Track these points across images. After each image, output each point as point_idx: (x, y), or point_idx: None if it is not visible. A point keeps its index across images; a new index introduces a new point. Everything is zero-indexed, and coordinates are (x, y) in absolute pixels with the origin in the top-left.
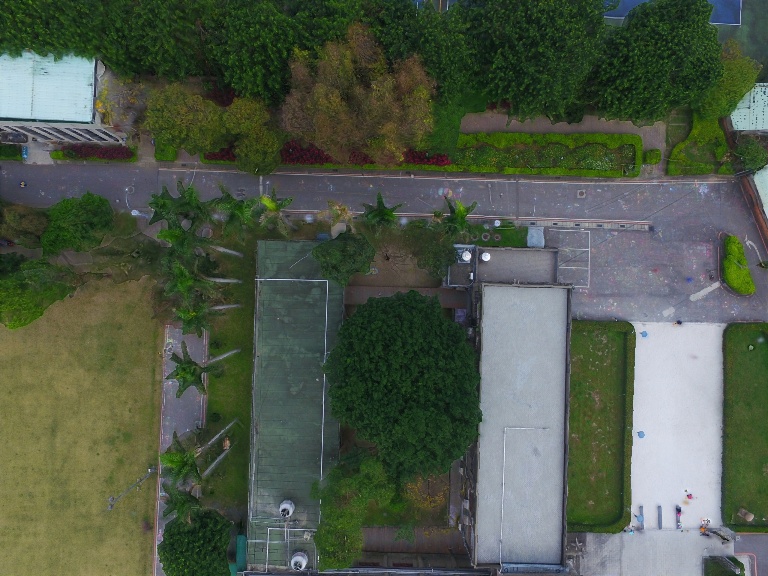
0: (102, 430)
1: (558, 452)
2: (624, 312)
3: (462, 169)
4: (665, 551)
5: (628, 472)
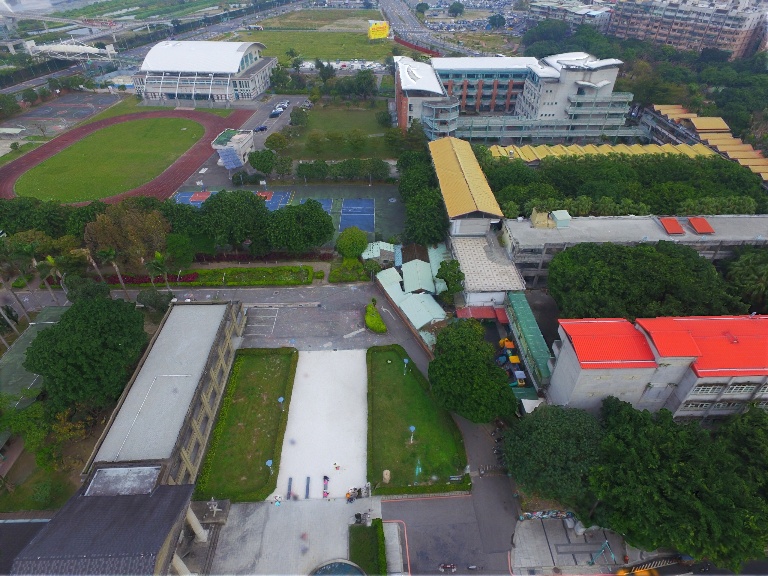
0: None
1: (193, 390)
2: (295, 346)
3: (201, 283)
4: (310, 521)
5: (278, 444)
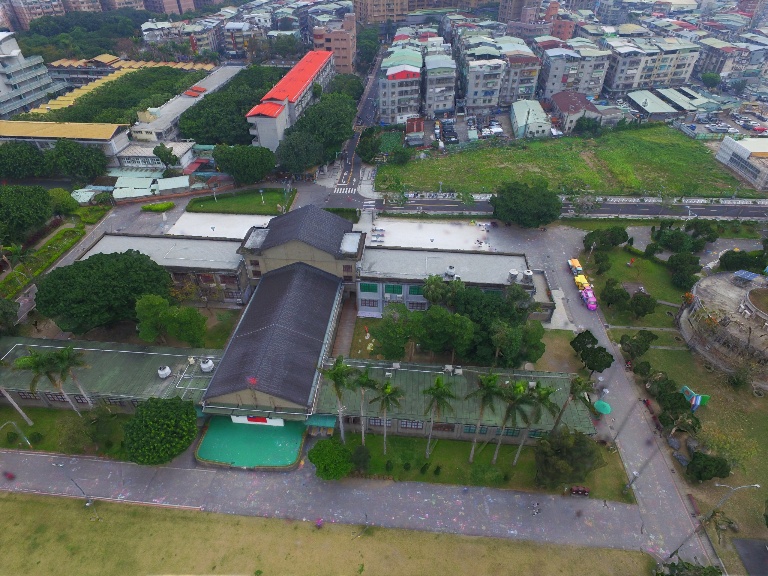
0: (16, 556)
1: None
2: None
3: (15, 292)
4: None
5: None
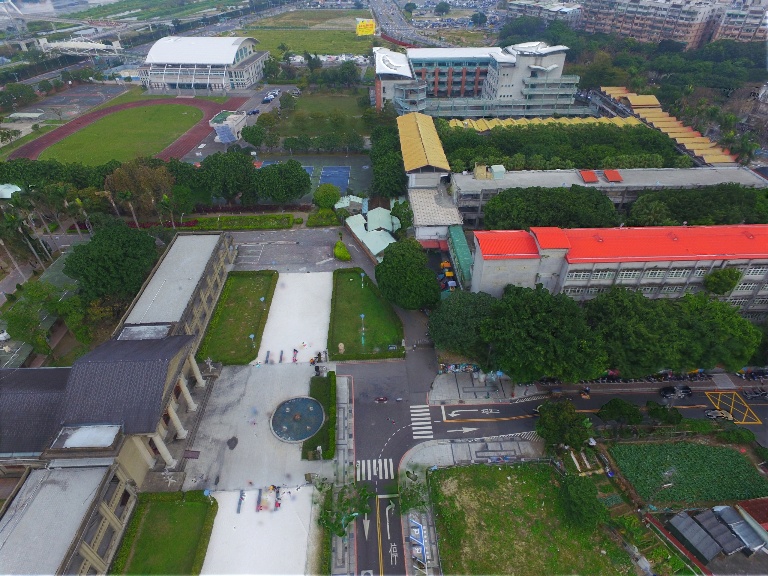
0: None
1: (194, 287)
2: None
3: (200, 228)
4: (282, 376)
5: (260, 330)
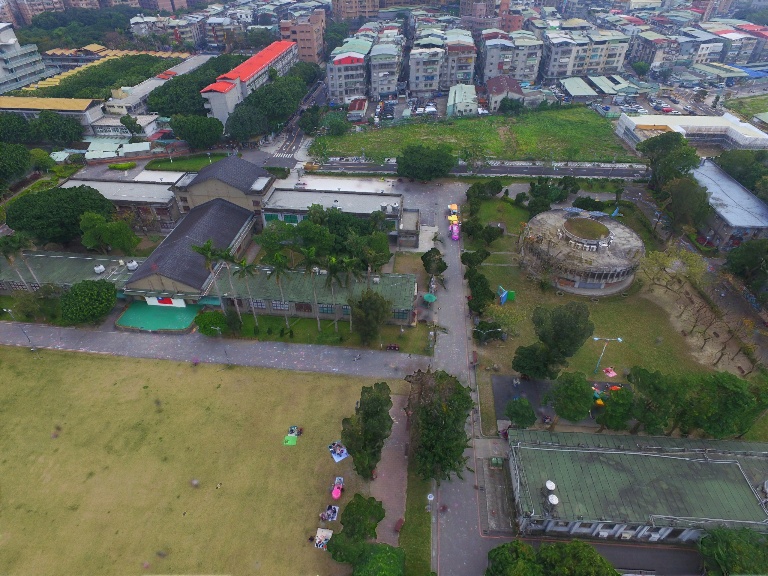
0: None
1: None
2: None
3: None
4: None
5: None
